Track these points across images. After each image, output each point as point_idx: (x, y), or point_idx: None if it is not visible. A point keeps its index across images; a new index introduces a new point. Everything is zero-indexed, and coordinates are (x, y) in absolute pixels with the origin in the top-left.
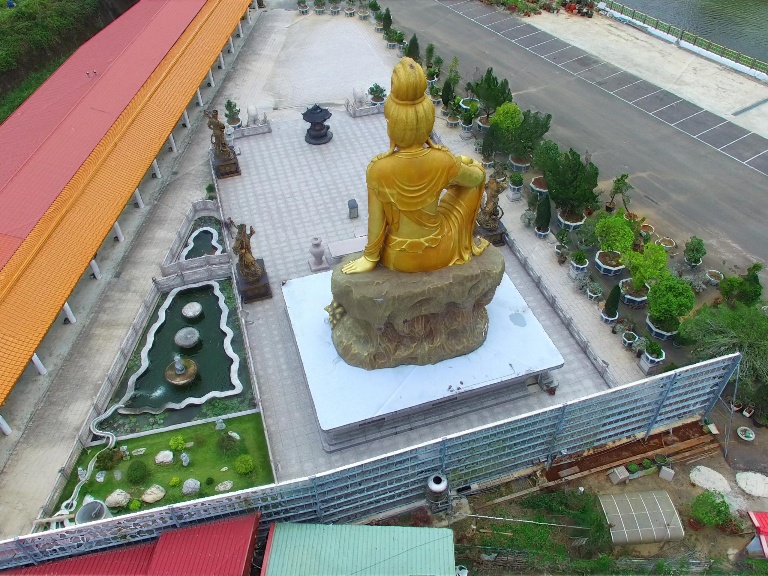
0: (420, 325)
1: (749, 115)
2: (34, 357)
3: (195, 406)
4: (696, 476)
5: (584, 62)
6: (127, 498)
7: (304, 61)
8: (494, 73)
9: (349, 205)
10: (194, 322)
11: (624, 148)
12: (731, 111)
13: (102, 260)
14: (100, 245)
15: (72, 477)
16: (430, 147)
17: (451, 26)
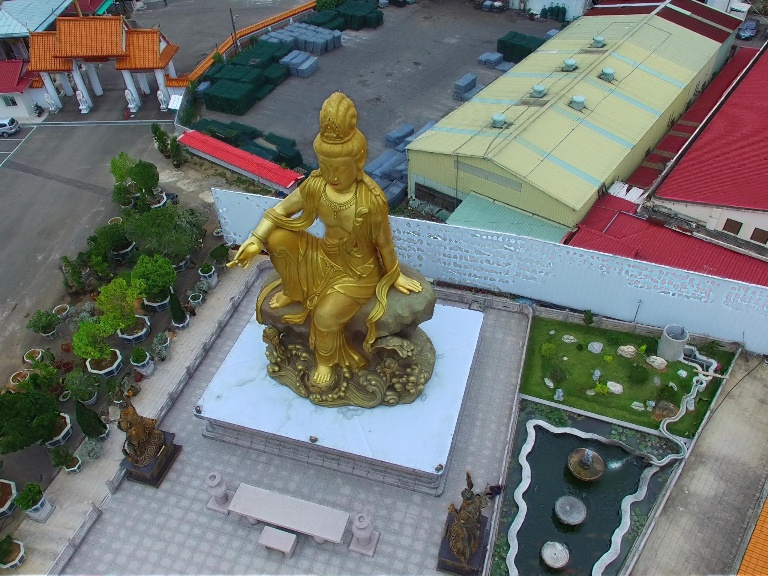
0: None
1: None
2: None
3: None
4: None
5: None
6: None
7: None
8: None
9: None
10: None
11: None
12: None
13: None
14: None
15: (702, 418)
16: None
17: None
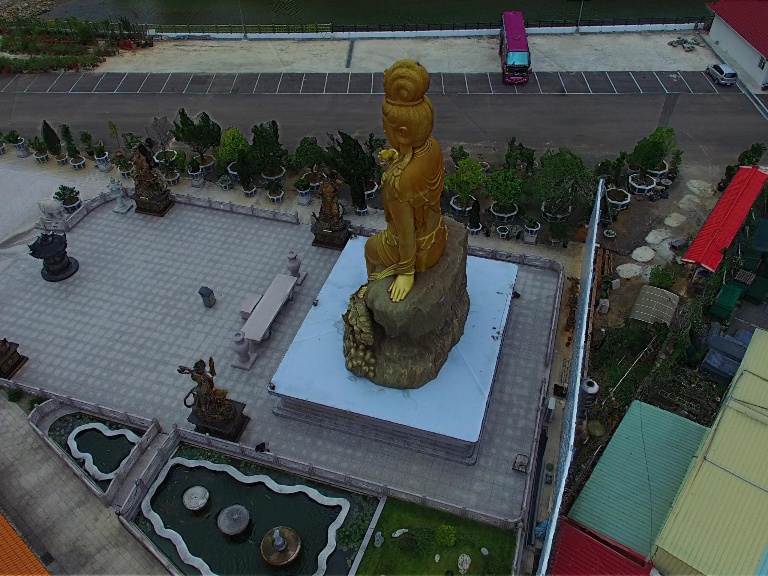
0: None
1: (356, 63)
2: None
3: (331, 556)
4: (623, 274)
5: (200, 81)
6: None
7: None
8: (140, 125)
9: (205, 295)
10: (207, 509)
11: (319, 125)
12: (343, 66)
13: None
14: (18, 538)
15: None
16: None
17: (34, 107)
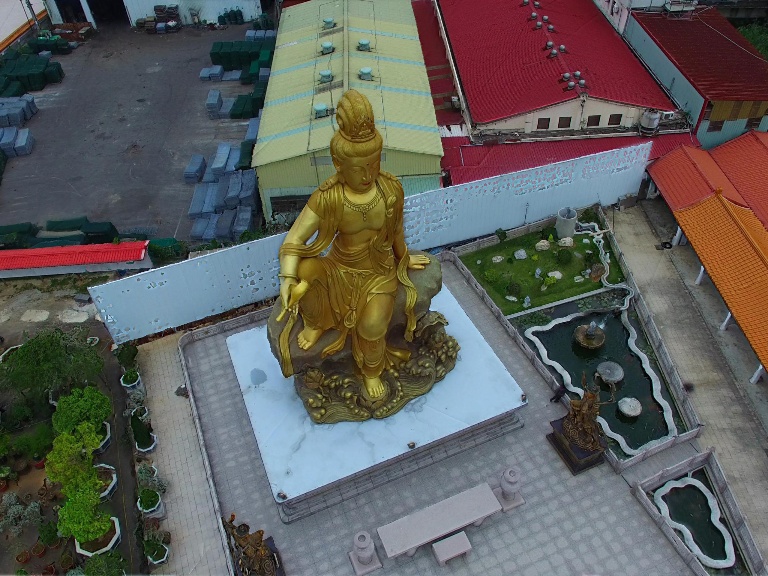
0: None
1: None
2: None
3: None
4: None
5: None
6: None
7: None
8: None
9: None
10: None
11: None
12: None
13: None
14: None
15: (618, 264)
16: None
17: None
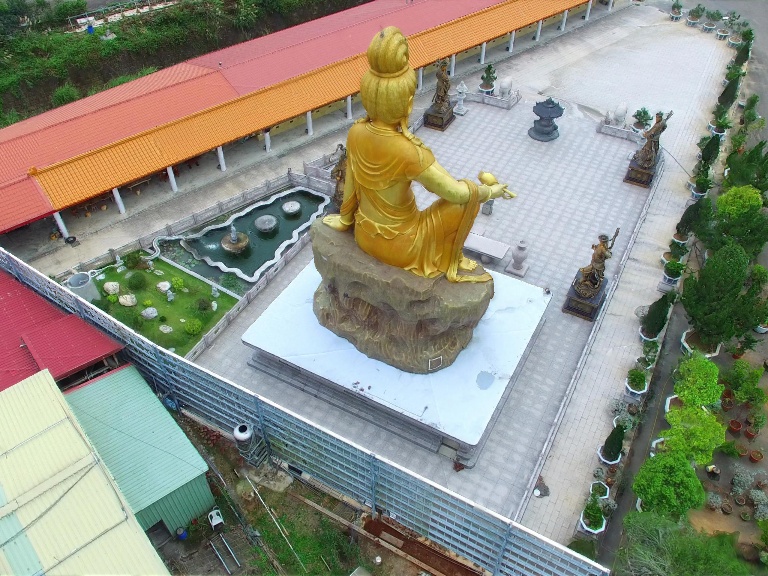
0: (364, 310)
1: None
2: (171, 174)
3: (220, 270)
4: None
5: None
6: (115, 291)
7: (618, 63)
8: None
9: None
10: (288, 217)
11: None
12: None
13: (284, 140)
14: (274, 124)
15: None
16: (402, 132)
17: None
